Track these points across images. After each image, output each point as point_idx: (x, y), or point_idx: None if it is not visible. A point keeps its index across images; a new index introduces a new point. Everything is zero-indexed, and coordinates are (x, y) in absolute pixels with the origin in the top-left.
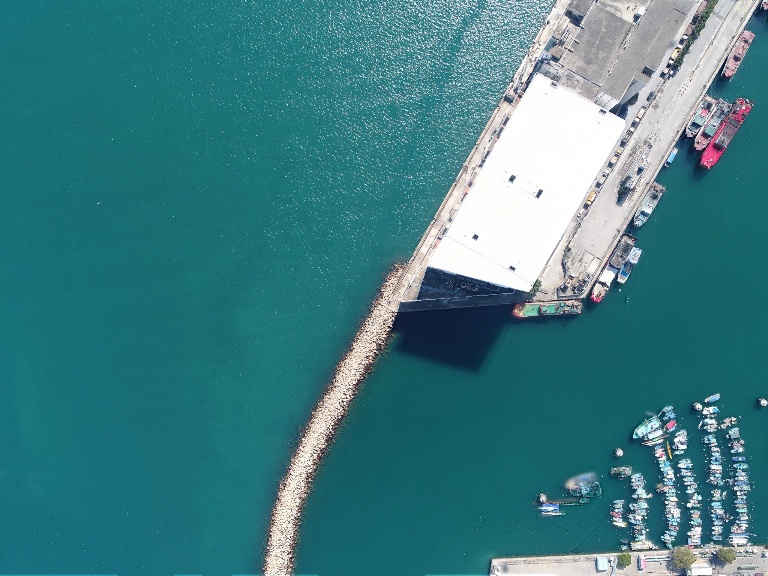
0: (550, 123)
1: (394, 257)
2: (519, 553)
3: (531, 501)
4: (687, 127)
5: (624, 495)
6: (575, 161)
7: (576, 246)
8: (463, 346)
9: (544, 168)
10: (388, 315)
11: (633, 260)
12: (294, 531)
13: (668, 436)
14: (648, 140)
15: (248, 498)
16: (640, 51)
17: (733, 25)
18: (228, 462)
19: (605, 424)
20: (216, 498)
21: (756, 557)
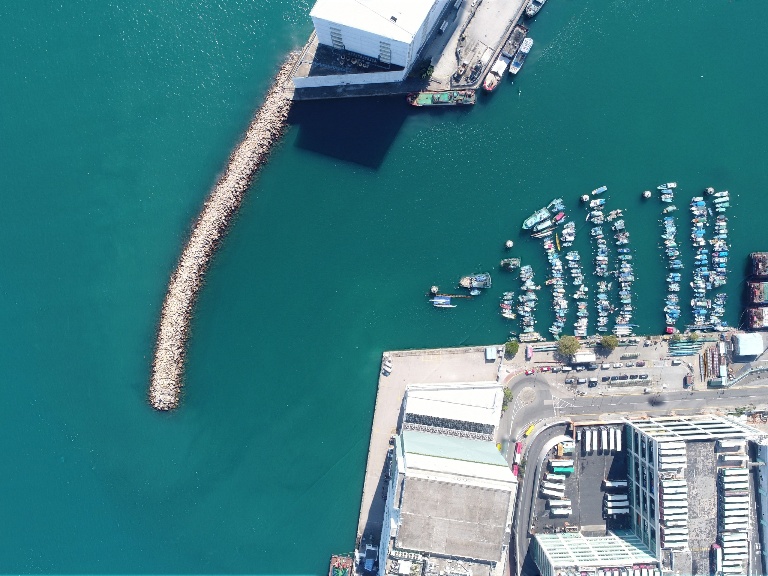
0: None
1: (290, 46)
2: (410, 345)
3: (423, 293)
4: None
5: (514, 287)
6: None
7: (470, 36)
8: (358, 137)
9: None
10: (282, 102)
11: (524, 49)
12: (185, 325)
13: (557, 228)
14: None
15: (138, 292)
16: None
17: None
18: (117, 252)
19: (496, 216)
20: (105, 293)
21: (638, 346)
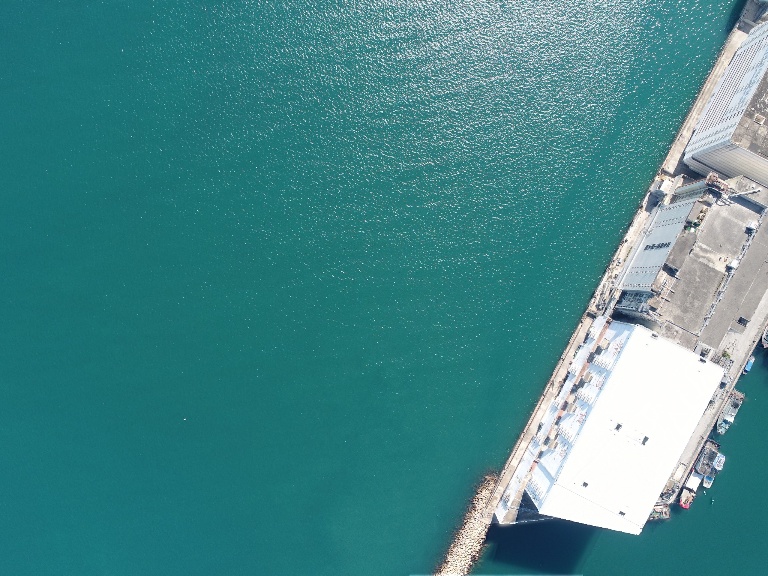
0: (653, 374)
1: (484, 468)
2: None
3: None
4: (763, 337)
5: None
6: (678, 408)
7: None
8: (556, 553)
9: (648, 416)
10: (482, 528)
11: (718, 467)
12: None
13: None
14: (726, 350)
15: None
16: (735, 302)
17: None
18: None
19: None
20: None
21: None
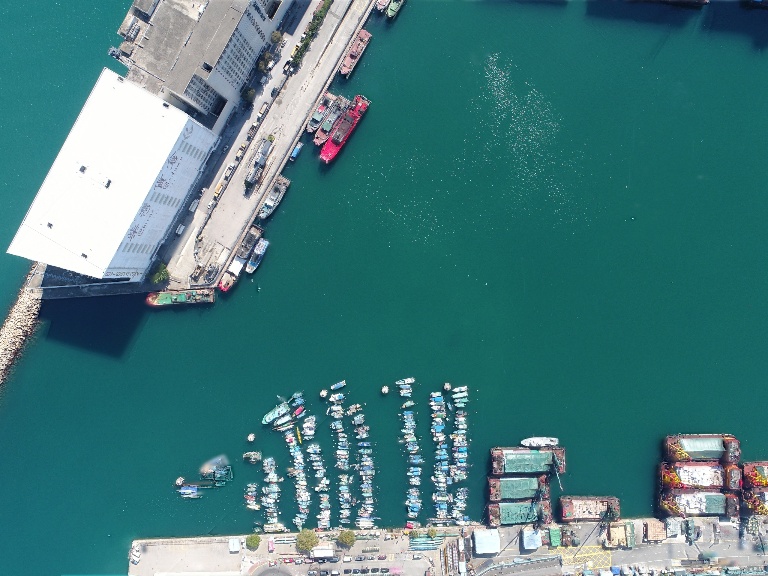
0: (116, 116)
1: None
2: (158, 534)
3: (170, 484)
4: (308, 122)
5: (258, 479)
6: (141, 153)
7: (207, 237)
8: (105, 333)
9: (113, 159)
10: (31, 302)
11: (257, 251)
12: None
13: (297, 422)
14: (273, 135)
15: None
16: (200, 47)
17: (351, 24)
18: None
19: (239, 410)
20: None
21: (380, 540)
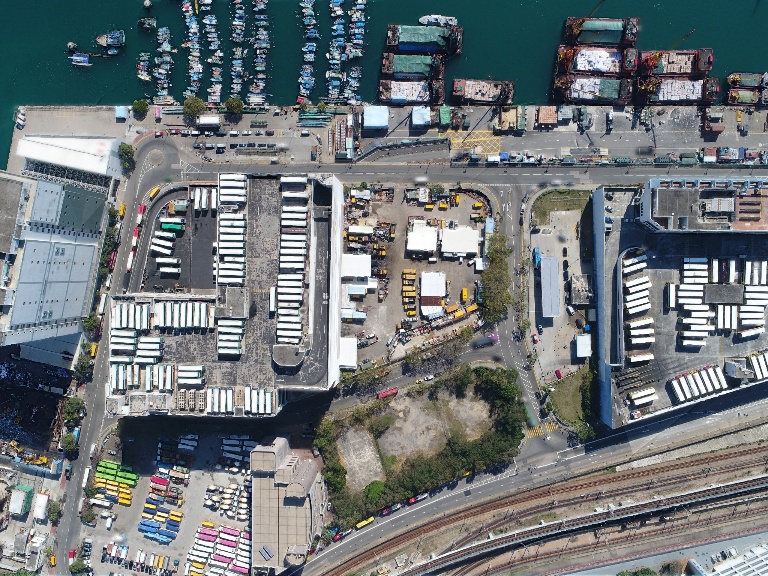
0: None
1: None
2: (46, 100)
3: (62, 50)
4: None
5: (151, 49)
6: None
7: None
8: None
9: None
10: None
11: None
12: None
13: None
14: None
15: None
16: None
17: None
18: None
19: None
20: None
21: (269, 115)
